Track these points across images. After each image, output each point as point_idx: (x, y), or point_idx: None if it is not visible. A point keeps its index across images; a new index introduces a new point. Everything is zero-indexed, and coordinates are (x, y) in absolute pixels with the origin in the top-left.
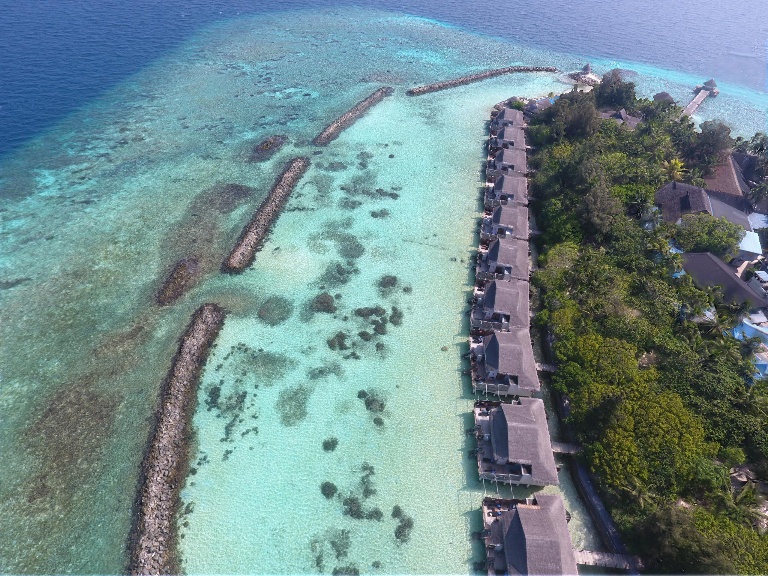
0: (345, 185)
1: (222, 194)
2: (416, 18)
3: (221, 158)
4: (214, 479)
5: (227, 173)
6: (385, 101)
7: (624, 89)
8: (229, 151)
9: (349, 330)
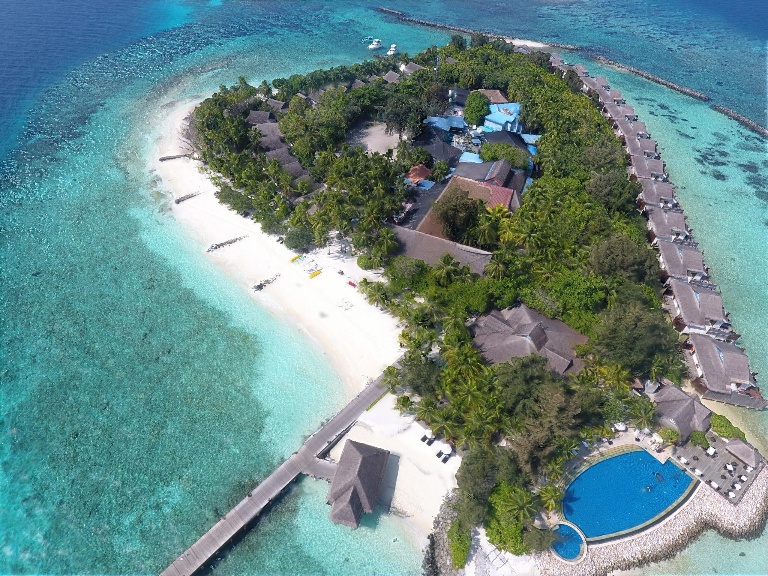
0: None
1: None
2: None
3: None
4: (730, 123)
5: None
6: None
7: None
8: None
9: (722, 157)
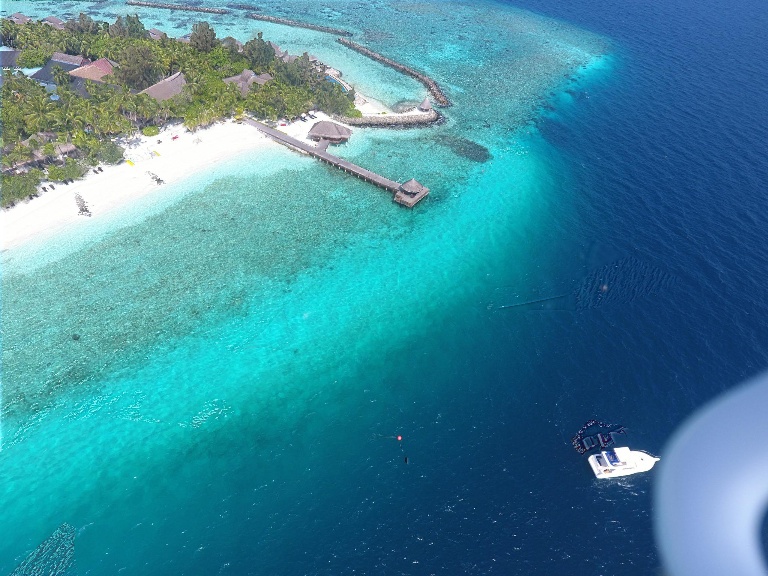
0: (194, 19)
1: (193, 1)
2: (594, 59)
3: (233, 1)
4: None
5: (215, 2)
6: (322, 33)
7: (275, 62)
8: (241, 2)
9: None
